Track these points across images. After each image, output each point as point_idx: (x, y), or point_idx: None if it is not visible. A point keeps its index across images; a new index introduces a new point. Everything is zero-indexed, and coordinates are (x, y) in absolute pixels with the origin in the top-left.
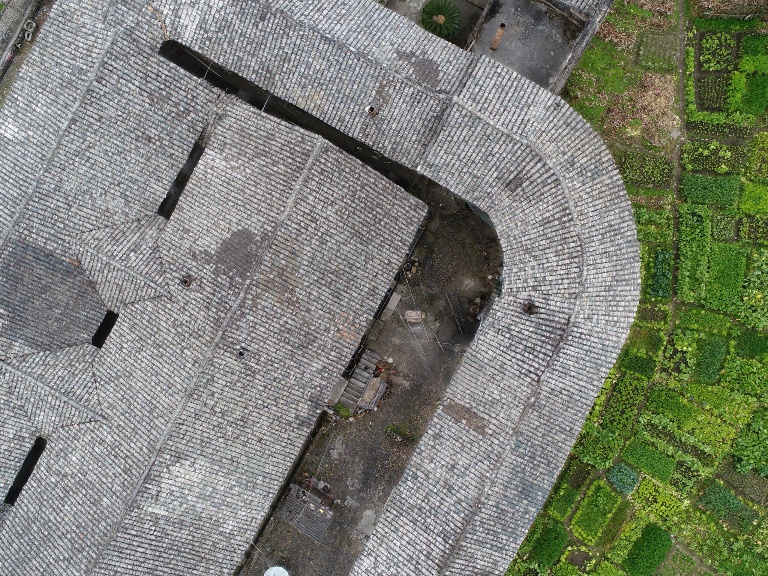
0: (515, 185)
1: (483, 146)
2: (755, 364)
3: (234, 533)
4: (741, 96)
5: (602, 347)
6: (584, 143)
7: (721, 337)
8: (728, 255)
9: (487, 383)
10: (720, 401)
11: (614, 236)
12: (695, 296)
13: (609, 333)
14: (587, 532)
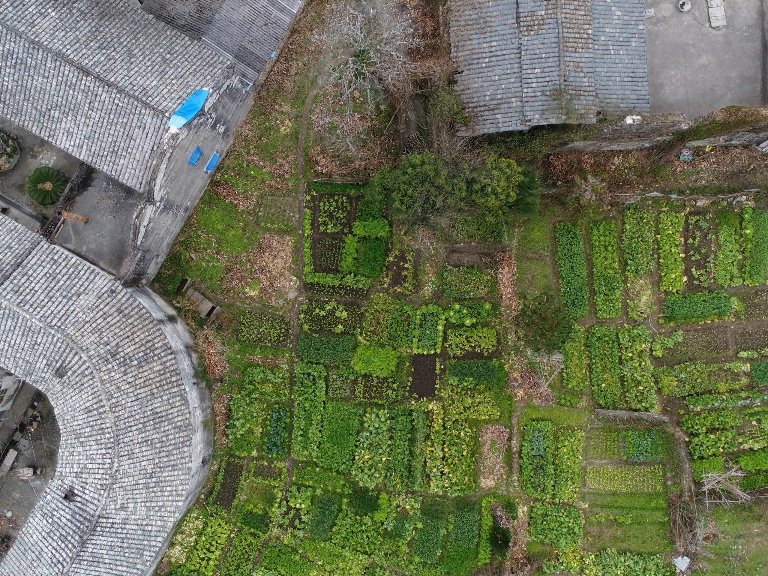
0: (60, 373)
1: (28, 336)
2: (366, 522)
3: None
4: (353, 259)
5: (143, 533)
6: (136, 330)
7: (336, 494)
8: (341, 414)
9: (26, 568)
10: (332, 557)
11: (160, 423)
12: (306, 455)
13: (152, 518)
14: None
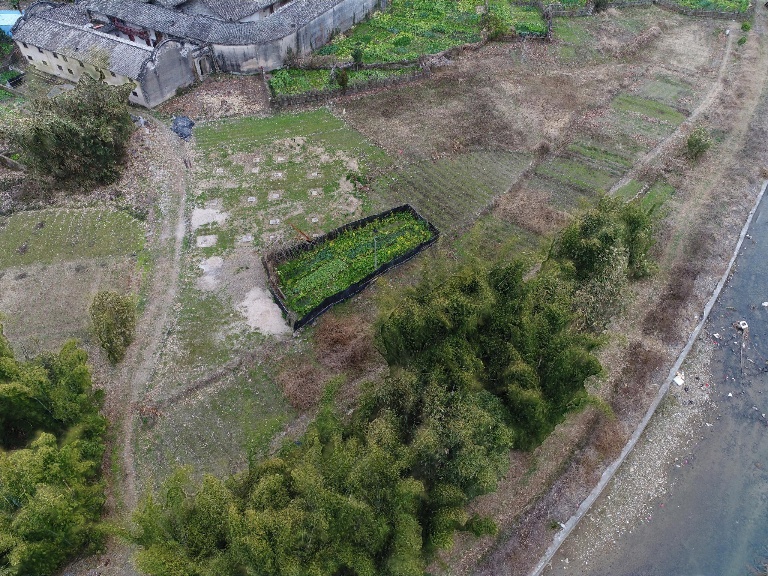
0: None
1: None
2: None
3: (258, 3)
4: None
5: None
6: None
7: None
8: None
9: None
10: None
11: None
12: (418, 6)
13: None
14: (380, 38)
